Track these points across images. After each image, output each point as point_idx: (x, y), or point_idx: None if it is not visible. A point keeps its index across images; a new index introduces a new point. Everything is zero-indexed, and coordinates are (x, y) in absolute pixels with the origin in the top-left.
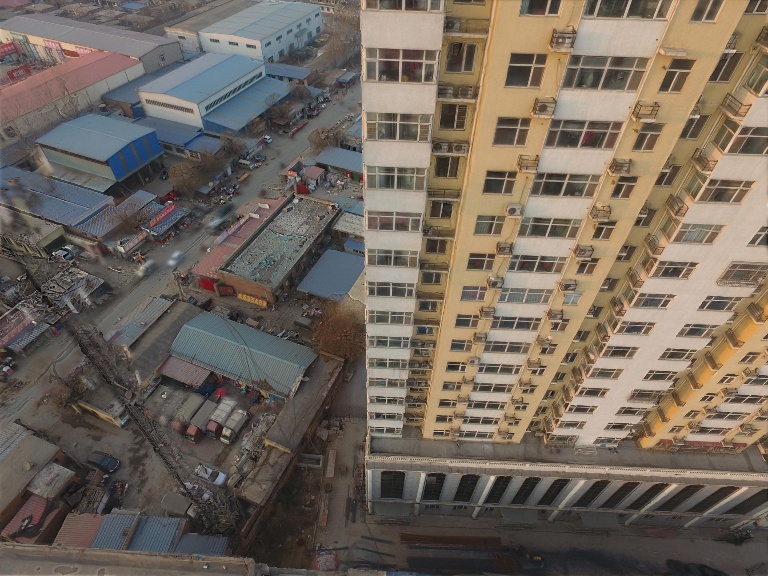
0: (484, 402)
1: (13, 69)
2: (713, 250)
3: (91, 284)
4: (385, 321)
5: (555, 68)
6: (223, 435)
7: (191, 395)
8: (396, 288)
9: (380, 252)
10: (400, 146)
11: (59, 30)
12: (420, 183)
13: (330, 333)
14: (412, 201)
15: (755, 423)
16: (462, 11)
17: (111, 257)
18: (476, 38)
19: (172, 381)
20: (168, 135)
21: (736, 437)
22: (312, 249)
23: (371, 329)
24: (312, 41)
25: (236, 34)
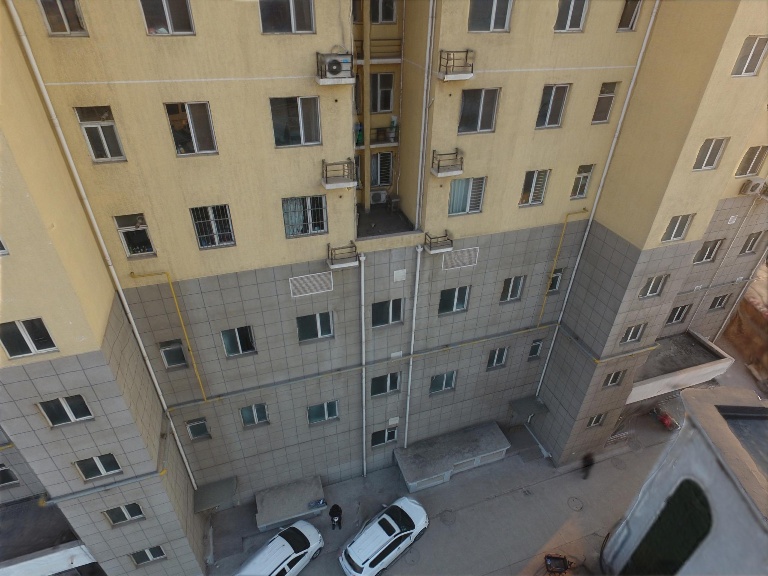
0: None
1: None
2: None
3: None
4: None
5: None
6: None
7: None
8: None
9: None
10: None
11: None
12: None
13: None
14: None
15: None
16: None
17: None
18: None
19: None
20: None
21: None
22: None
23: None
24: None
25: None
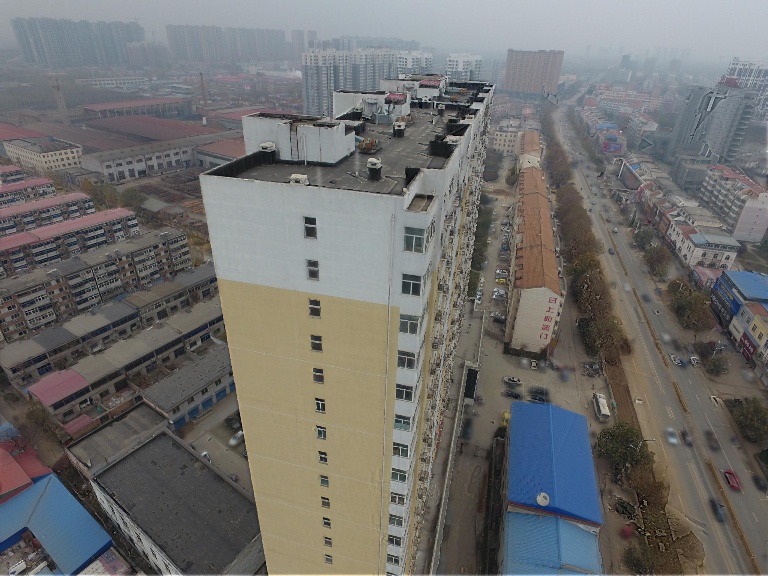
0: None
1: None
2: None
3: None
4: None
5: None
6: None
7: None
8: None
9: None
10: None
11: None
12: None
13: None
14: None
15: None
16: None
17: None
18: None
19: None
20: None
21: None
22: None
23: None
24: None
25: None
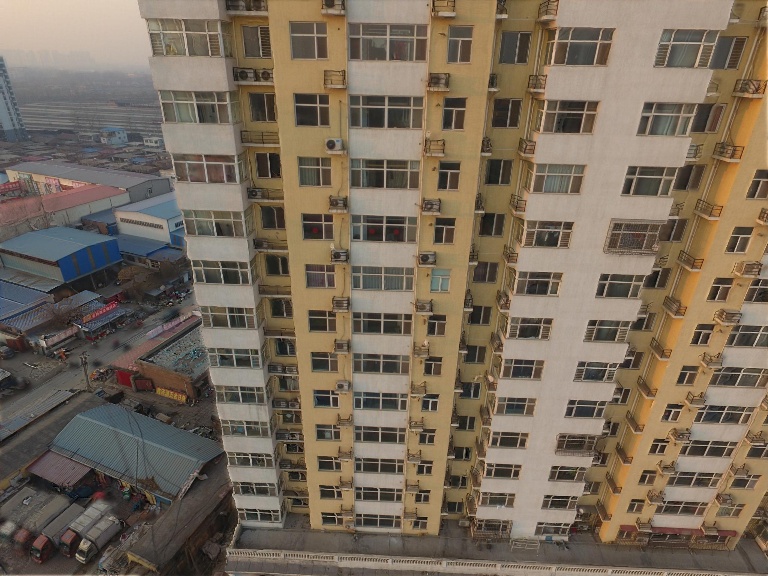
0: (375, 461)
1: (8, 198)
2: (583, 202)
3: None
4: (225, 325)
5: None
6: (79, 550)
7: (56, 497)
8: (227, 270)
9: (198, 215)
10: (191, 62)
11: (62, 170)
12: (224, 114)
13: None
14: (219, 138)
15: (734, 492)
16: None
17: (31, 353)
18: None
19: (43, 483)
20: (134, 247)
21: (718, 519)
22: None
23: (208, 337)
24: None
25: None
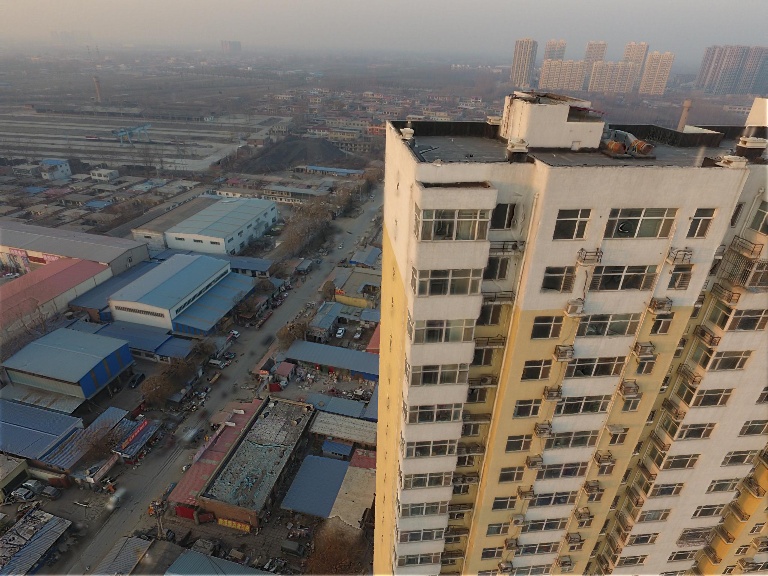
0: None
1: None
2: (668, 524)
3: (56, 529)
4: None
5: (539, 440)
6: None
7: None
8: None
9: (409, 556)
10: (429, 491)
11: (26, 238)
12: (443, 509)
13: (326, 568)
14: (437, 521)
15: None
16: (470, 407)
17: (77, 489)
18: (482, 423)
19: None
20: (137, 340)
21: None
22: (291, 457)
23: None
24: (269, 230)
25: (201, 233)
